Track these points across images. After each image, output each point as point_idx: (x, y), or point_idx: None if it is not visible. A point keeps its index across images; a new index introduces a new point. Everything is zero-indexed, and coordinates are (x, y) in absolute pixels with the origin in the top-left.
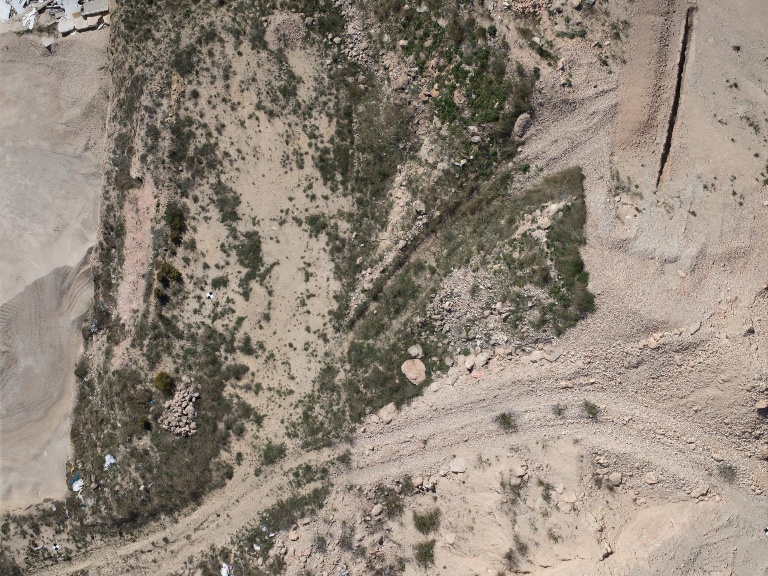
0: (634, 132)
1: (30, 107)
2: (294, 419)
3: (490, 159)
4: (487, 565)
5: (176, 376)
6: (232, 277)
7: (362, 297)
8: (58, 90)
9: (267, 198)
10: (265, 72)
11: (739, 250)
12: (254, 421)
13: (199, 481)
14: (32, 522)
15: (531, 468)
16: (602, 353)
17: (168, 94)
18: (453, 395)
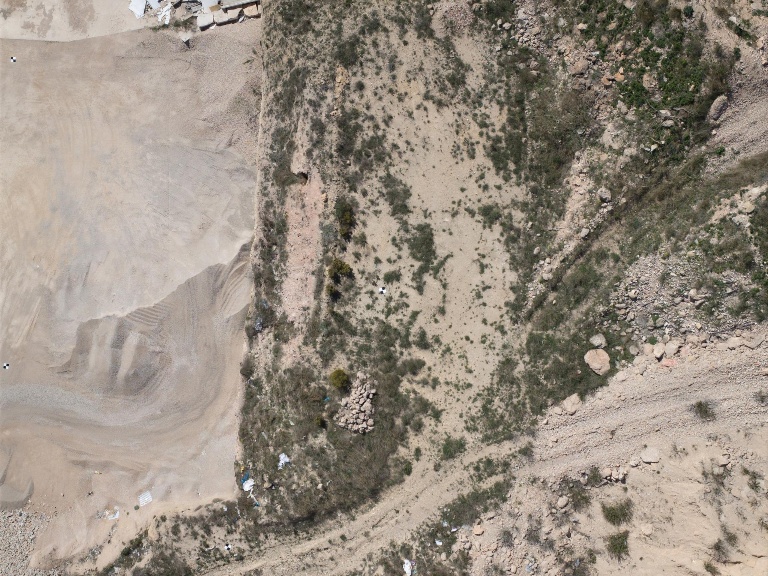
0: None
1: (169, 104)
2: (473, 413)
3: (682, 143)
4: (690, 556)
5: (350, 373)
6: (405, 271)
7: (540, 287)
8: (197, 85)
9: (438, 190)
10: (432, 61)
11: None
12: (432, 416)
13: (378, 478)
14: (203, 523)
15: (733, 457)
16: None
17: (332, 87)
18: (643, 384)
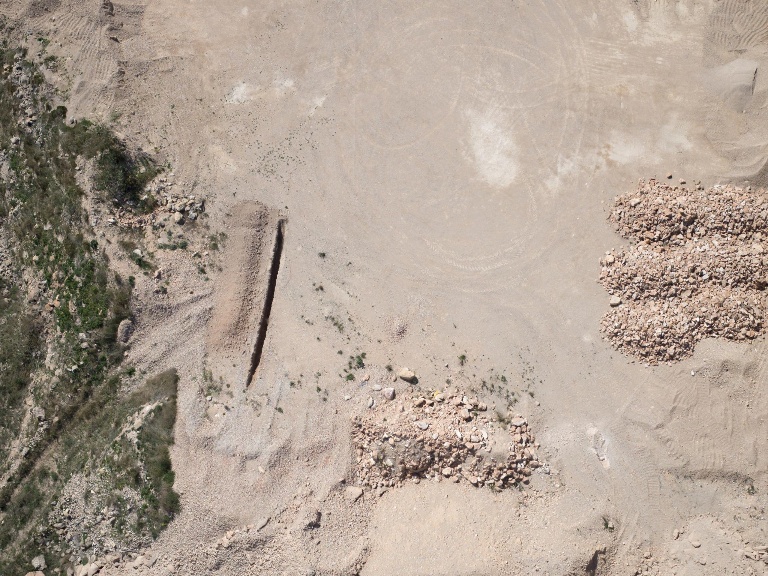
0: (226, 334)
1: None
2: None
3: (100, 364)
4: None
5: None
6: None
7: None
8: None
9: None
10: None
11: (321, 444)
12: None
13: None
14: None
15: None
16: (188, 555)
17: None
18: None
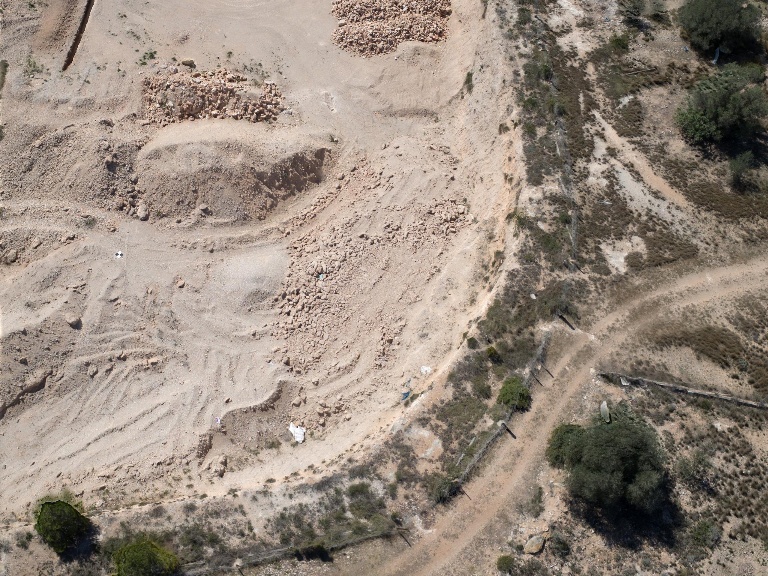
0: (48, 39)
1: None
2: None
3: None
4: None
5: None
6: None
7: None
8: None
9: None
10: None
11: (119, 99)
12: None
13: None
14: None
15: None
16: (7, 166)
17: None
18: None
